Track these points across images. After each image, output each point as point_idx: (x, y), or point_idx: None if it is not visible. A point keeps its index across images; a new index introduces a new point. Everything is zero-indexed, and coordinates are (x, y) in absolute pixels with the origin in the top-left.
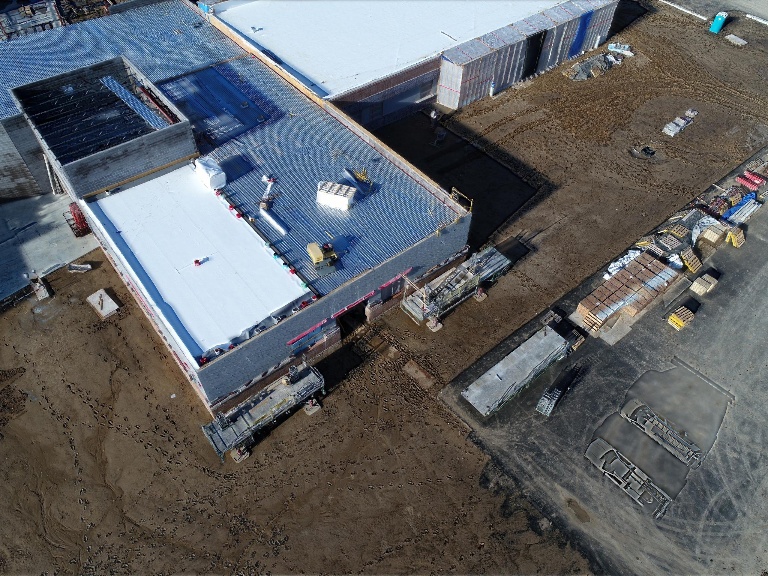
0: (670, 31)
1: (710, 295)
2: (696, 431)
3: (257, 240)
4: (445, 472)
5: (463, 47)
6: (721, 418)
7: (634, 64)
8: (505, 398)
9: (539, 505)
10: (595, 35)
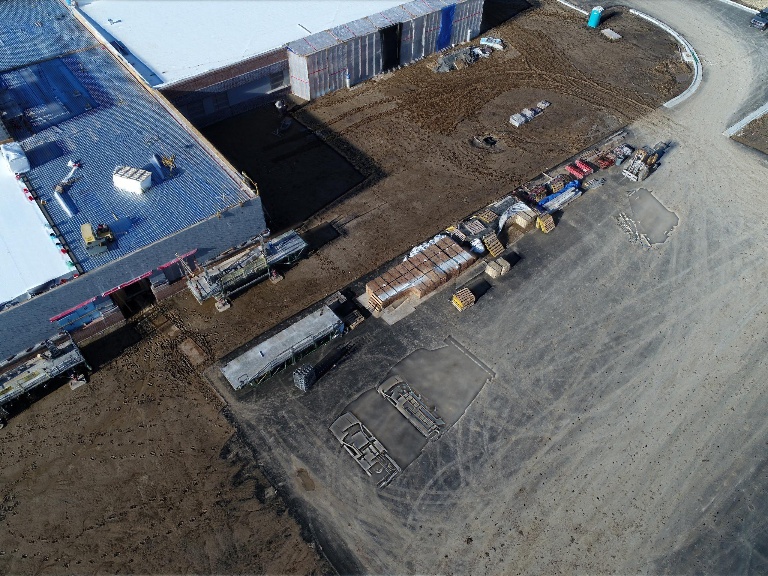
0: (548, 25)
1: (504, 278)
2: (446, 406)
3: (41, 221)
4: (190, 443)
5: (310, 39)
6: (475, 394)
7: (502, 57)
8: (261, 373)
9: (269, 474)
10: (465, 29)
